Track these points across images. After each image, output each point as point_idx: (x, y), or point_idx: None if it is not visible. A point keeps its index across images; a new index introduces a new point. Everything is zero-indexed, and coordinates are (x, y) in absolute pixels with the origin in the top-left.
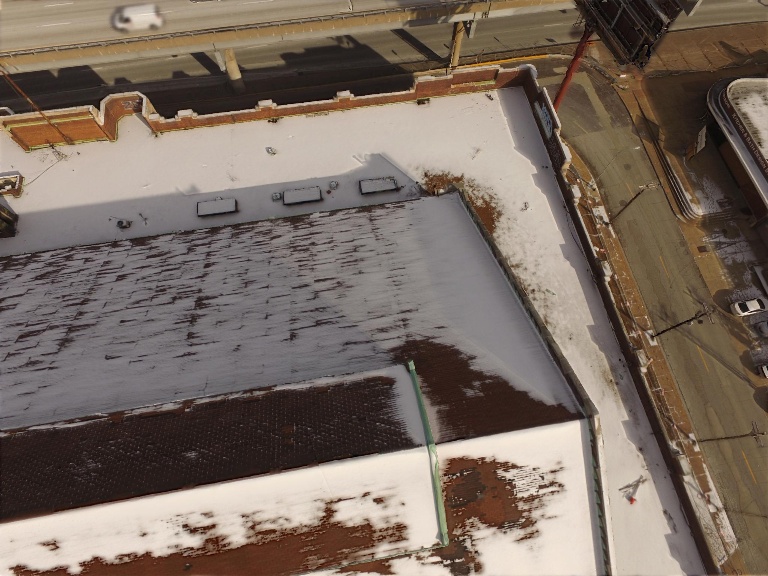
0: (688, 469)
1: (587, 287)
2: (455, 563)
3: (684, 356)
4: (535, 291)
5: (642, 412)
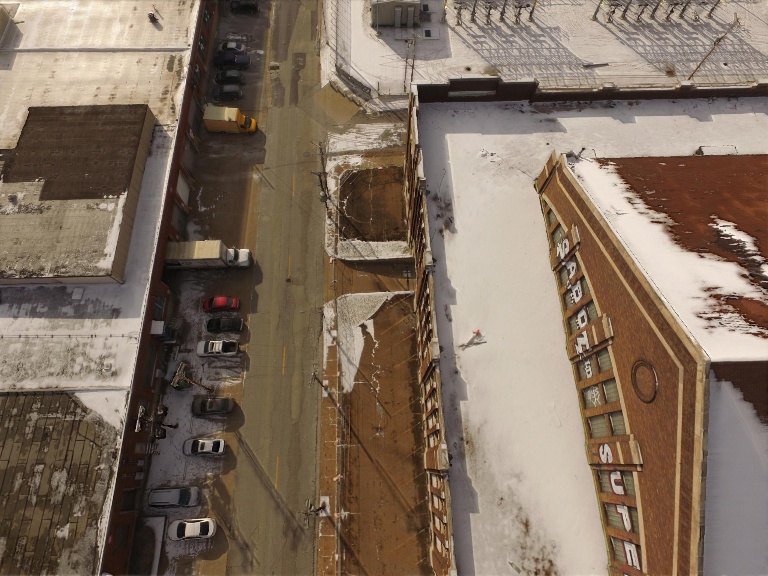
0: (435, 346)
1: (467, 568)
2: (767, 281)
3: (296, 478)
4: (535, 572)
5: (445, 406)
